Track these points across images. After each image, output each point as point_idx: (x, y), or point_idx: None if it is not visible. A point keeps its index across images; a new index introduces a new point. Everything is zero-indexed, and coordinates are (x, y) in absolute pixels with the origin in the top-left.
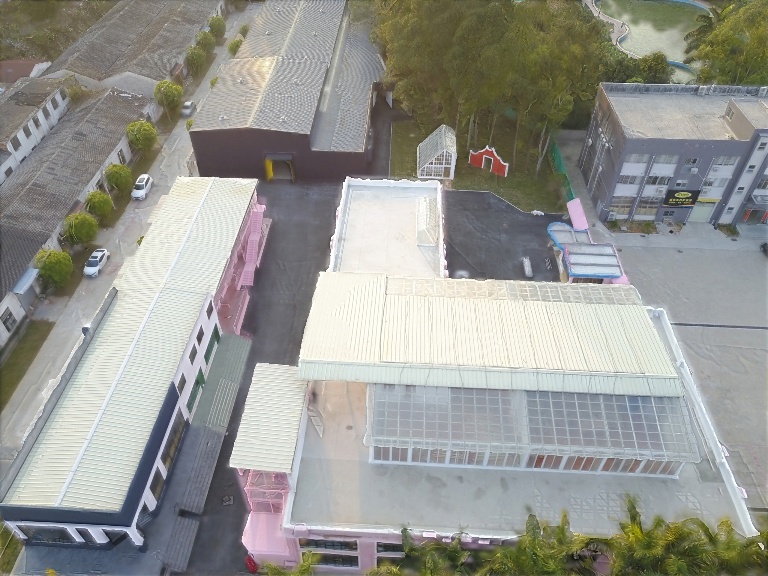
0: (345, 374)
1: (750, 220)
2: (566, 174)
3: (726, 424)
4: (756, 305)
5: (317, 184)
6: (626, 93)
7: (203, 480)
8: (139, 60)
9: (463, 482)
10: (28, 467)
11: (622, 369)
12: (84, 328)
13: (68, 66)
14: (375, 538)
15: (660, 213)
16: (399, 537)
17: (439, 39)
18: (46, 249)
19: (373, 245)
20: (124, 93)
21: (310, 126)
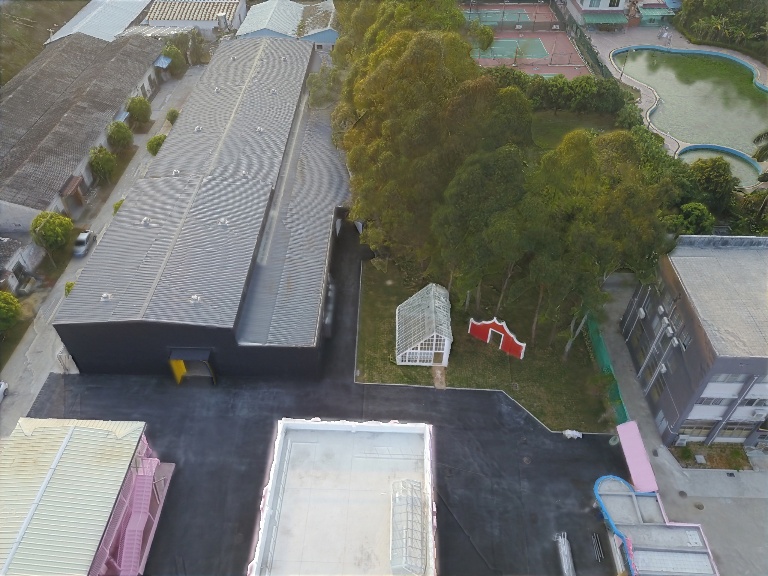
0: None
1: None
2: (610, 366)
3: None
4: None
5: (250, 385)
6: (695, 248)
7: None
8: (15, 178)
9: None
10: None
11: None
12: None
13: None
14: None
15: (753, 436)
16: None
17: (424, 190)
18: None
19: None
20: None
21: (235, 311)
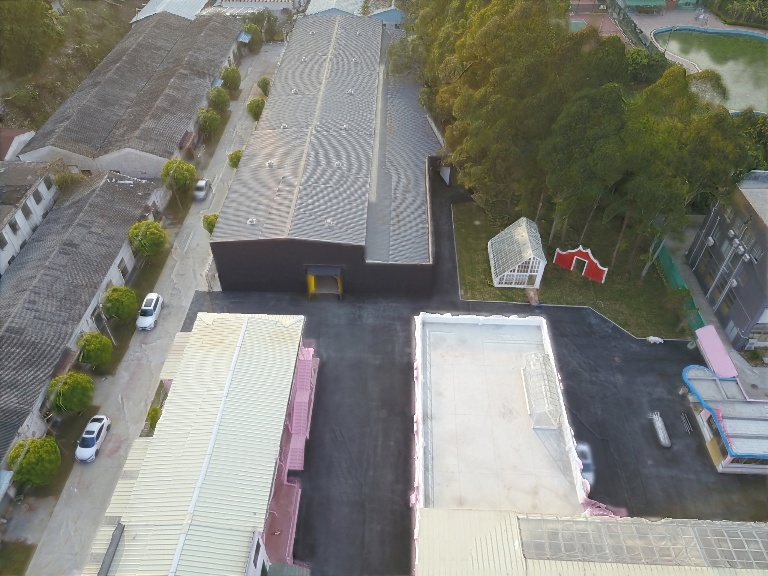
0: None
1: None
2: (685, 285)
3: None
4: None
5: (371, 301)
6: (759, 182)
7: None
8: (141, 131)
9: None
10: None
11: None
12: None
13: (54, 141)
14: None
15: None
16: None
17: (533, 125)
18: (24, 431)
19: (472, 428)
20: (124, 179)
21: (364, 232)
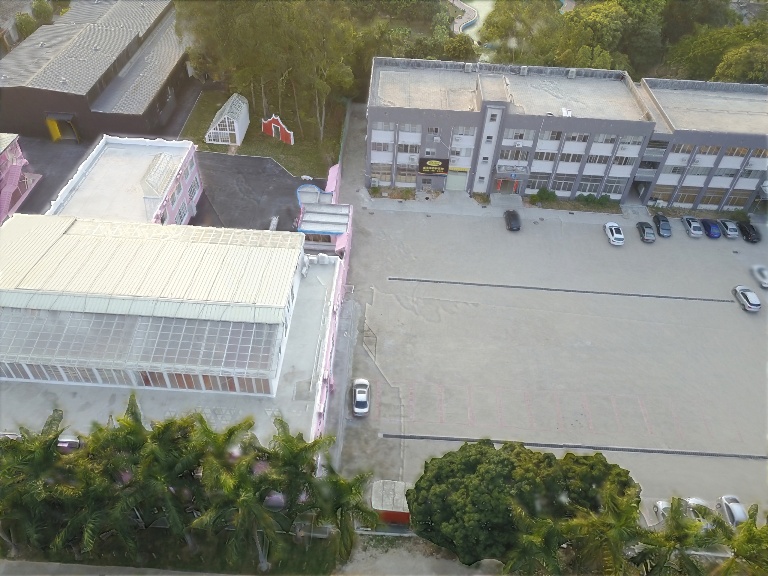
0: None
1: (503, 190)
2: (341, 143)
3: (398, 364)
4: (477, 264)
5: None
6: (399, 68)
7: None
8: None
9: (75, 397)
10: None
11: (238, 299)
12: None
13: None
14: None
15: (419, 181)
16: None
17: (206, 7)
18: None
19: (101, 196)
20: None
21: (89, 88)
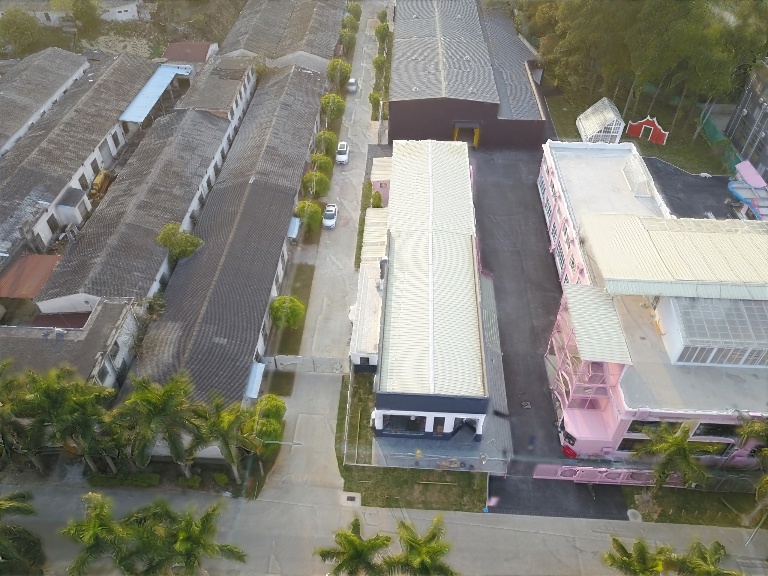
0: (649, 289)
1: None
2: None
3: None
4: None
5: (498, 150)
6: None
7: (500, 389)
8: (306, 41)
9: (759, 378)
10: (388, 367)
11: None
12: (384, 260)
13: (244, 46)
14: (703, 419)
15: None
16: (725, 418)
17: (623, 16)
18: None
19: (595, 196)
20: (306, 70)
21: (497, 96)
